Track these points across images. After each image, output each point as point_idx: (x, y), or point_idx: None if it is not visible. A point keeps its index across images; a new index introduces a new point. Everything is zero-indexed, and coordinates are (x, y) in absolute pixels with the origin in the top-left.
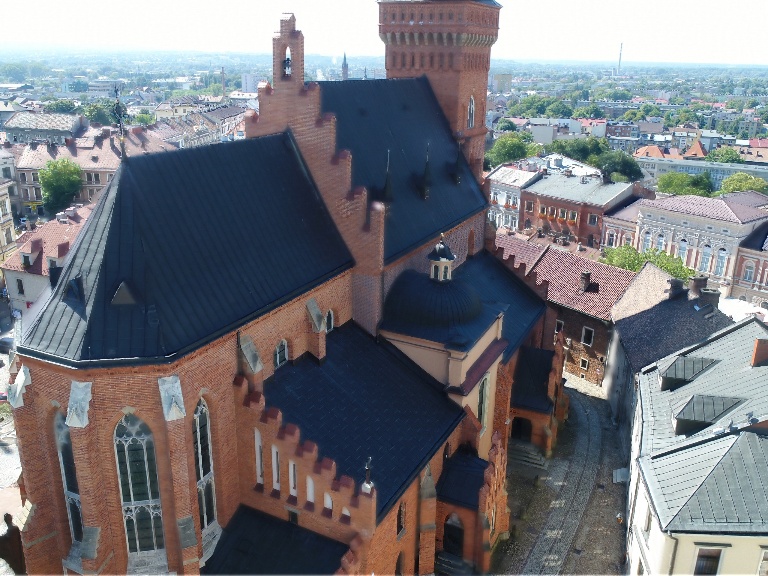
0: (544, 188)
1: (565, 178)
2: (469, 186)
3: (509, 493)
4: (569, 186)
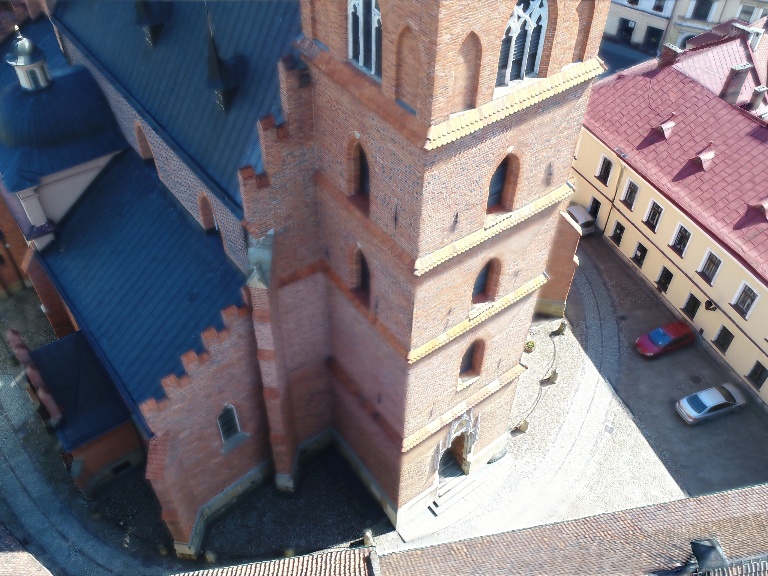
0: None
1: None
2: (246, 143)
3: (31, 332)
4: None
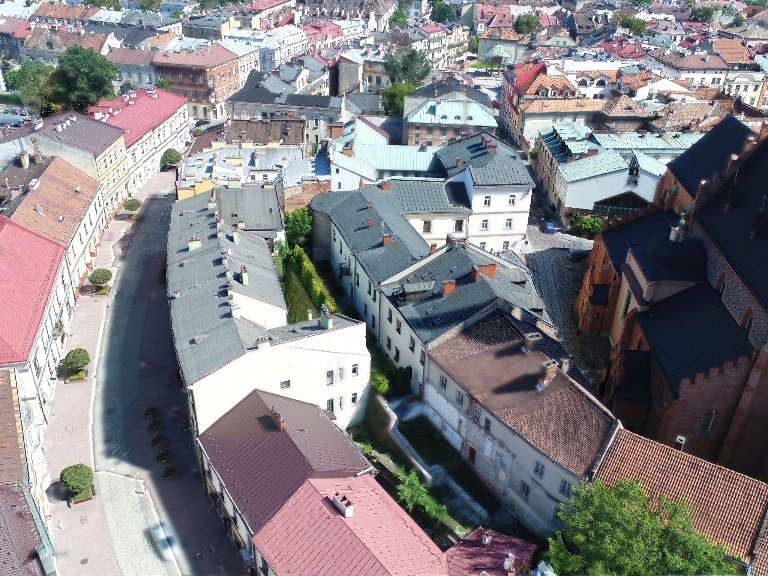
0: None
1: None
2: None
3: (597, 355)
4: None
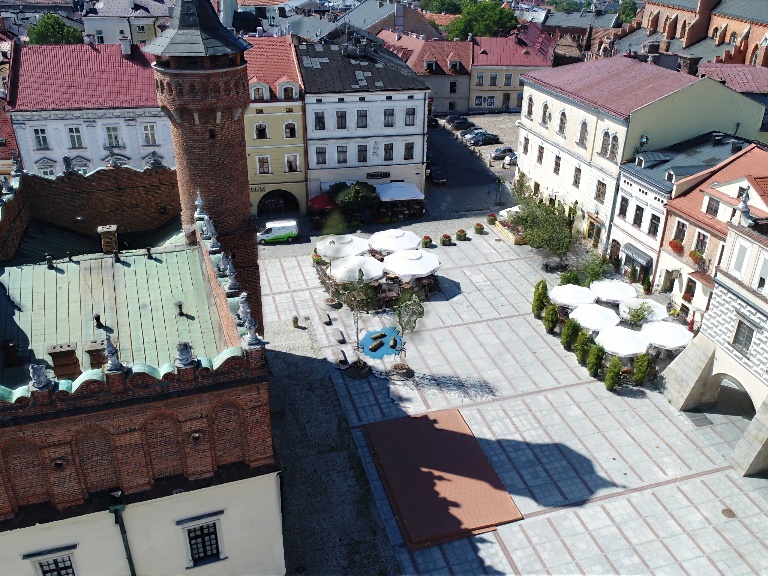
0: (558, 22)
1: (566, 14)
2: None
3: None
4: (575, 19)
